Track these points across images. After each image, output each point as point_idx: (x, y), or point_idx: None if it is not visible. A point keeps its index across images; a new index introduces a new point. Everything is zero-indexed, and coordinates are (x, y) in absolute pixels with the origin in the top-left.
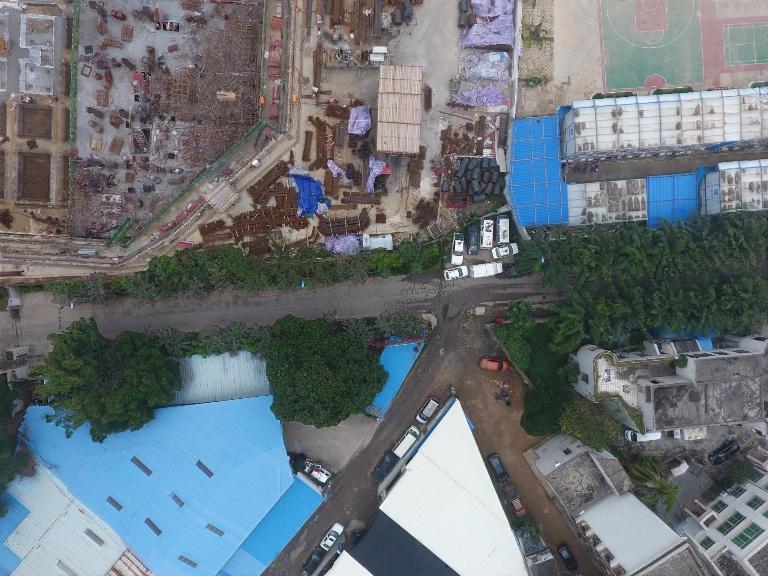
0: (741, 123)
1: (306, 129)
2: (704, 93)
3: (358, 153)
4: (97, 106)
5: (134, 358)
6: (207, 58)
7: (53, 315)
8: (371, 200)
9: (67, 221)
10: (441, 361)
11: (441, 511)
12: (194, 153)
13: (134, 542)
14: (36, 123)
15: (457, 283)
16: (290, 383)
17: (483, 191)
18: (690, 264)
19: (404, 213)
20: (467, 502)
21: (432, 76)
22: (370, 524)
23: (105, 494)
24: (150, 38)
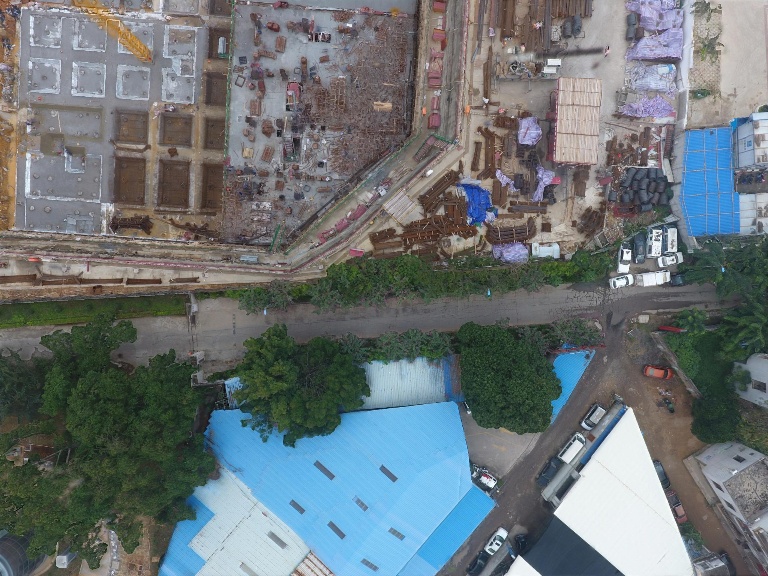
0: None
1: (475, 139)
2: None
3: (527, 163)
4: (250, 115)
5: (332, 364)
6: (363, 69)
7: (228, 321)
8: (538, 209)
9: (224, 228)
10: (604, 368)
11: (613, 517)
12: (343, 162)
13: (317, 545)
14: (176, 131)
15: (621, 291)
16: (498, 390)
17: (650, 201)
18: None
19: (569, 222)
20: (639, 508)
21: None
22: (544, 529)
23: (288, 497)
24: (302, 49)
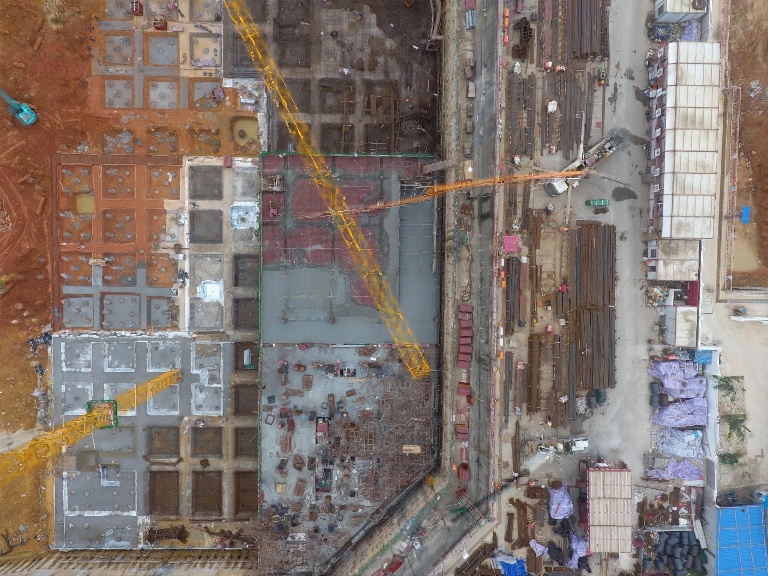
0: None
1: (507, 510)
2: None
3: (560, 534)
4: (281, 453)
5: None
6: (389, 411)
7: None
8: (573, 575)
9: (263, 574)
10: None
11: None
12: (373, 489)
13: None
14: (207, 441)
15: None
16: None
17: (684, 565)
18: None
19: None
20: None
21: (626, 452)
22: None
23: None
24: (329, 384)
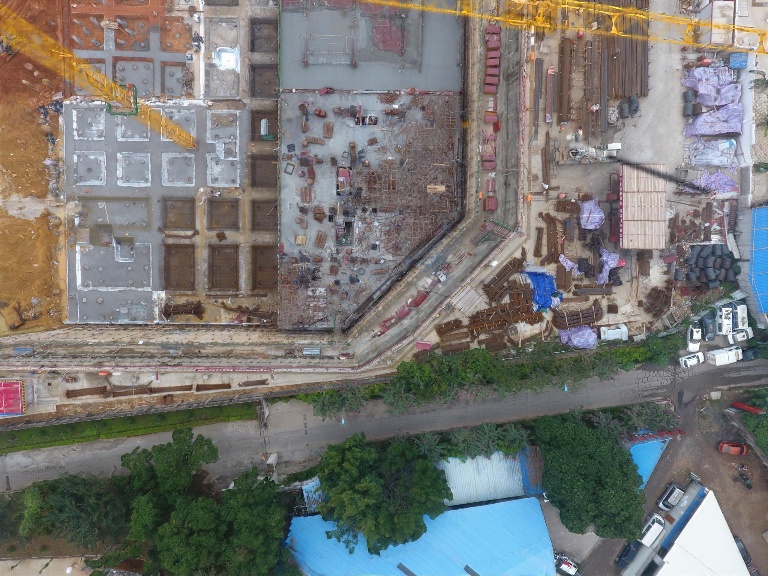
0: None
1: (536, 225)
2: None
3: (591, 247)
4: (302, 203)
5: (416, 474)
6: (413, 152)
7: (299, 421)
8: (603, 291)
9: None
10: (679, 447)
11: None
12: (396, 242)
13: None
14: (223, 215)
15: (691, 369)
16: (589, 498)
17: (716, 278)
18: None
19: (635, 302)
20: None
21: None
22: None
23: None
24: (350, 133)
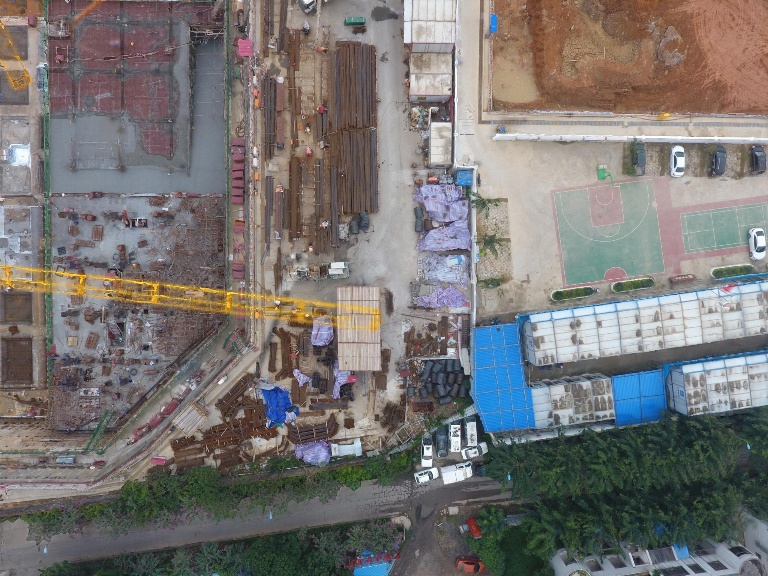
0: (702, 326)
1: (271, 340)
2: (662, 299)
3: (323, 362)
4: (72, 305)
5: None
6: (175, 257)
7: None
8: (338, 406)
9: None
10: (417, 563)
11: None
12: (168, 343)
13: None
14: (17, 308)
15: (429, 483)
16: None
17: (449, 393)
18: (658, 479)
19: (372, 416)
20: None
21: (392, 280)
22: None
23: None
24: (120, 235)
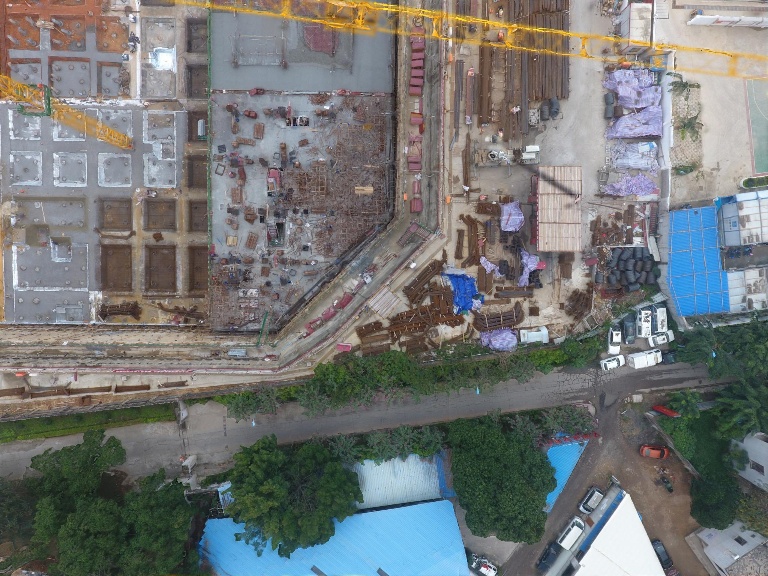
0: None
1: (457, 227)
2: None
3: (511, 249)
4: (232, 204)
5: (323, 476)
6: (342, 153)
7: (218, 423)
8: (524, 294)
9: (212, 320)
10: (600, 450)
11: None
12: (327, 244)
13: None
14: (160, 215)
15: (613, 372)
16: (490, 501)
17: (637, 280)
18: None
19: (557, 305)
20: None
21: None
22: None
23: None
24: (281, 134)
